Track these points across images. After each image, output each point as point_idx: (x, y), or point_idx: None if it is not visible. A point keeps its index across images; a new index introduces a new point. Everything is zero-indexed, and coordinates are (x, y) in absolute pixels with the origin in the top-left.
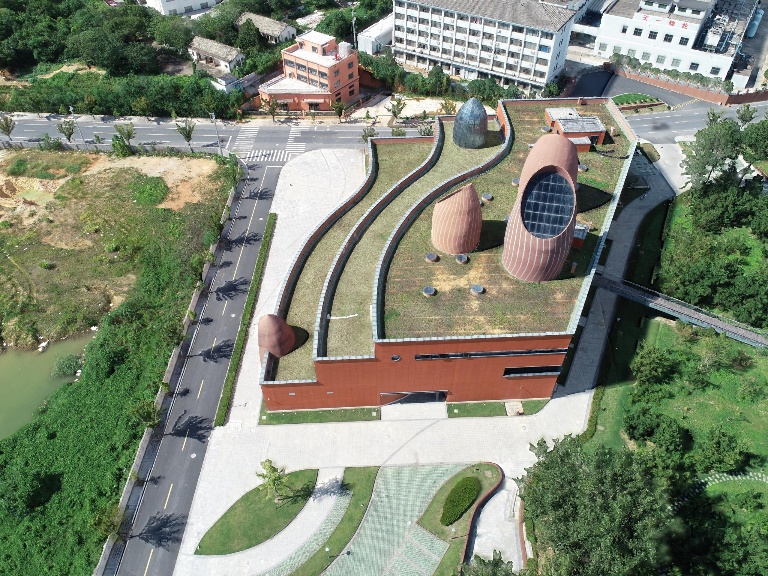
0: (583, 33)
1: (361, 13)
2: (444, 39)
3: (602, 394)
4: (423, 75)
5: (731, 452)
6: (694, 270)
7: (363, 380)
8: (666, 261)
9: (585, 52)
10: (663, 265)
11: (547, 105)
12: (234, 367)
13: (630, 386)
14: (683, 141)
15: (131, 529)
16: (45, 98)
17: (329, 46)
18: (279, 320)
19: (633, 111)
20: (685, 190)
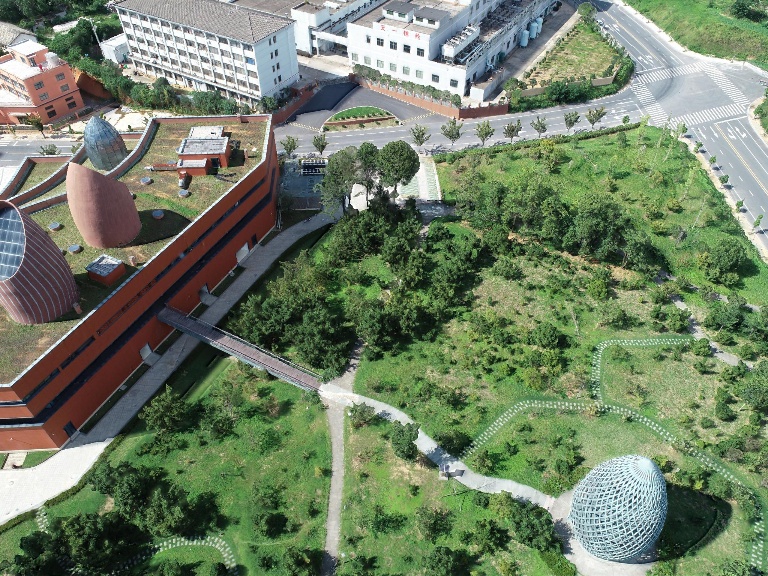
0: None
1: None
2: (169, 49)
3: (117, 444)
4: None
5: (169, 517)
6: None
7: None
8: None
9: (343, 62)
10: (250, 299)
11: (205, 123)
12: None
13: (151, 435)
14: None
15: None
16: None
17: (39, 56)
18: None
19: (358, 126)
20: None
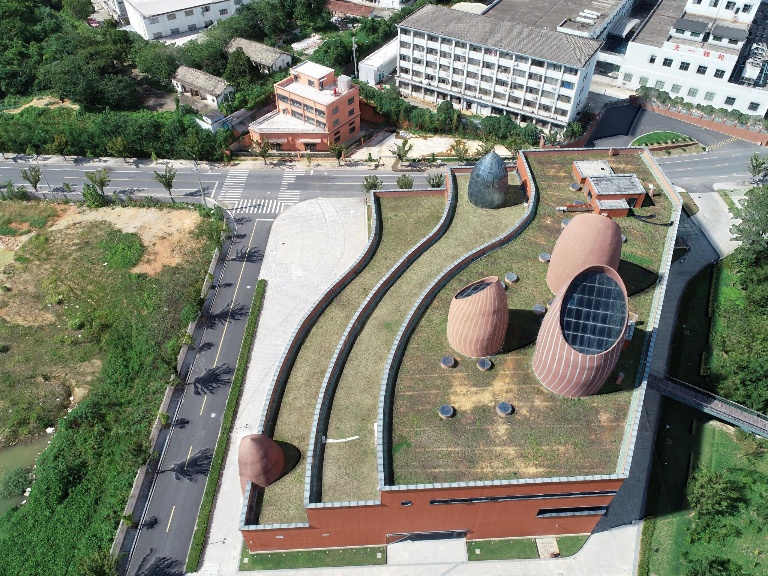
0: (605, 61)
1: (362, 37)
2: (454, 71)
3: (653, 528)
4: (431, 109)
5: None
6: (756, 367)
7: (366, 523)
8: (720, 352)
9: (608, 82)
10: (717, 356)
11: (574, 156)
12: (212, 488)
13: (686, 517)
14: (723, 189)
15: None
16: (11, 137)
17: (327, 79)
18: (264, 443)
19: (664, 152)
20: (730, 251)
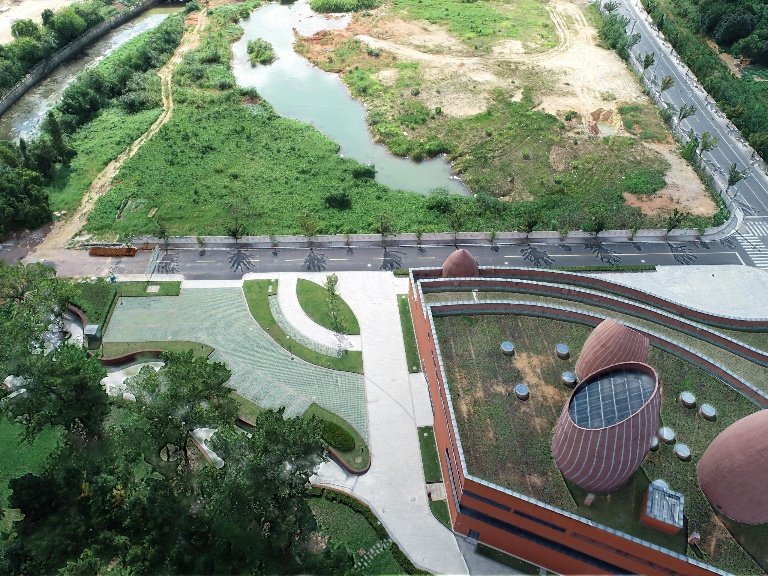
0: None
1: None
2: None
3: None
4: None
5: None
6: None
7: None
8: None
9: None
10: None
11: None
12: None
13: None
14: None
15: (316, 248)
16: (728, 90)
17: None
18: (465, 261)
19: None
20: None
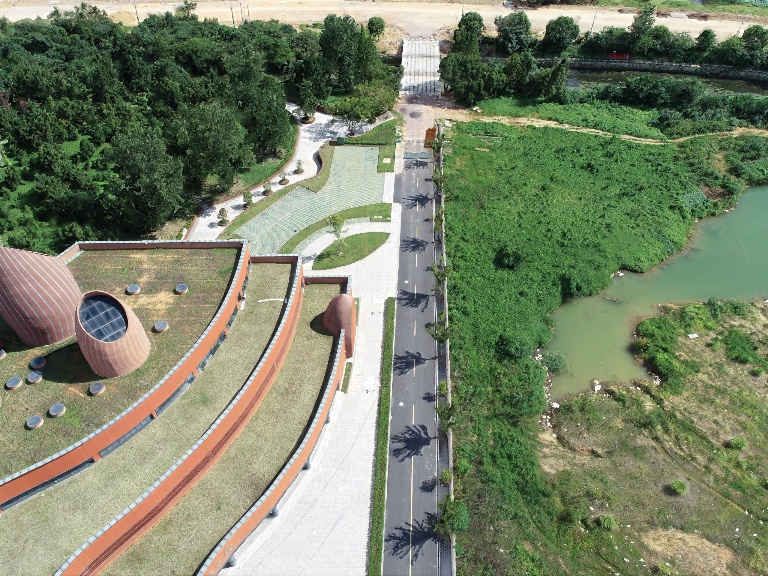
0: None
1: None
2: None
3: None
4: None
5: None
6: None
7: None
8: None
9: None
10: None
11: None
12: (387, 341)
13: None
14: None
15: None
16: None
17: None
18: (334, 302)
19: None
20: None
